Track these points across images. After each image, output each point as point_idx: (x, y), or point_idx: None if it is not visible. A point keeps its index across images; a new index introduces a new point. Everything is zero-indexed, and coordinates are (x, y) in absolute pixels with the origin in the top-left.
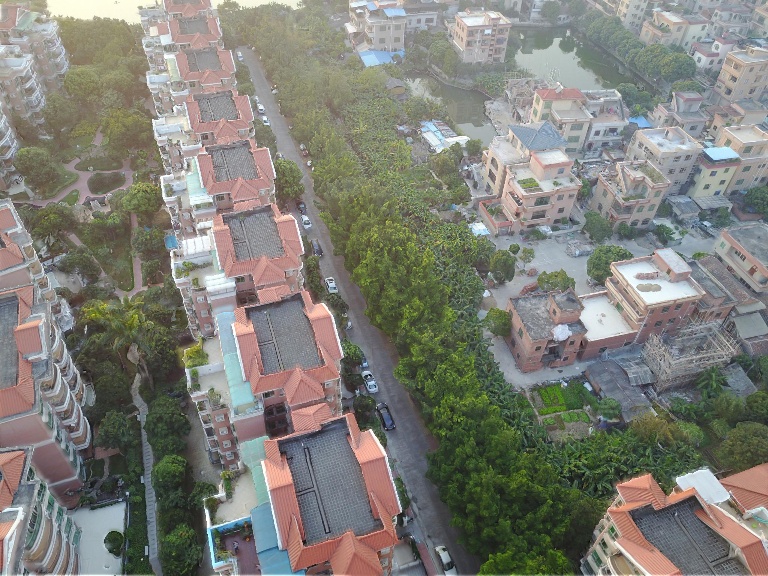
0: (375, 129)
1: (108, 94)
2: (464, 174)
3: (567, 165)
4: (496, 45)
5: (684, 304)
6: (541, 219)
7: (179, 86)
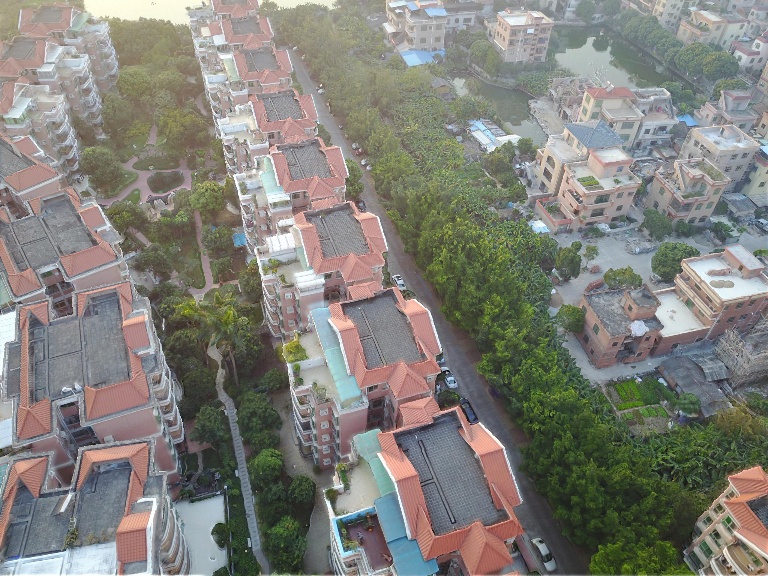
0: (425, 128)
1: (162, 94)
2: (517, 172)
3: (627, 163)
4: (538, 44)
5: (758, 300)
6: (600, 217)
7: (237, 86)
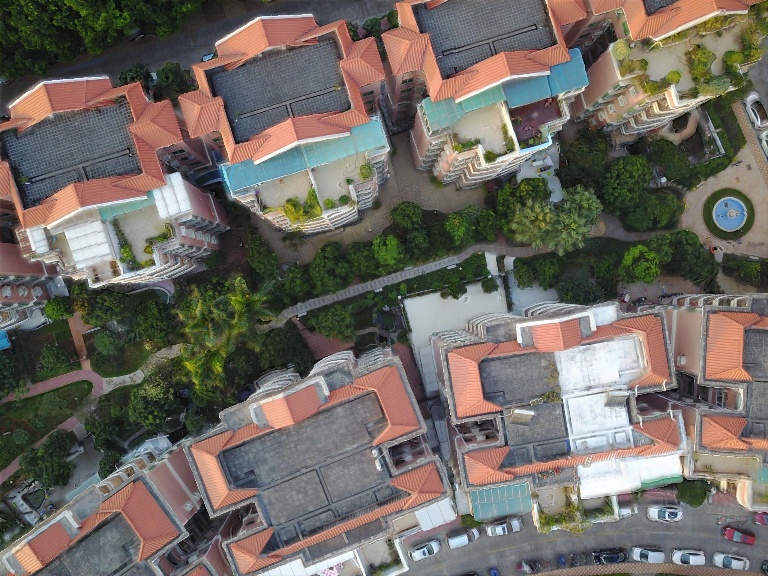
0: None
1: None
2: None
3: None
4: None
5: None
6: None
7: None
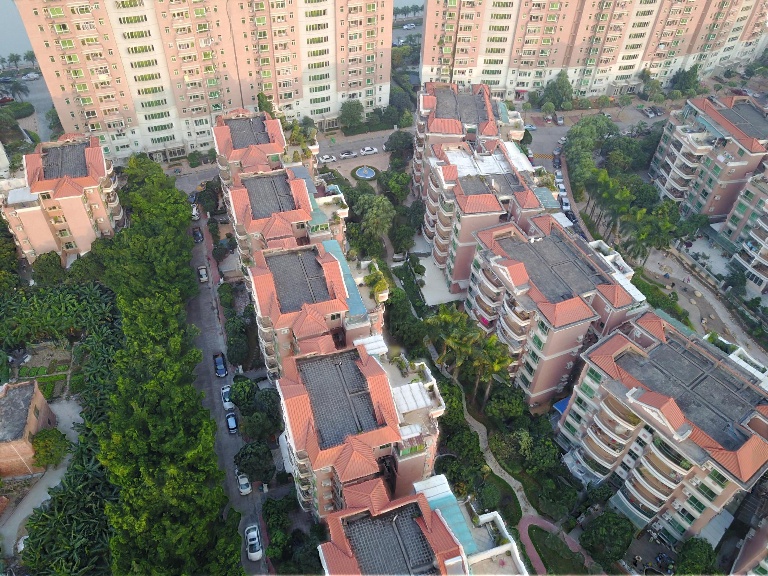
0: None
1: None
2: None
3: None
4: None
5: None
6: None
7: None
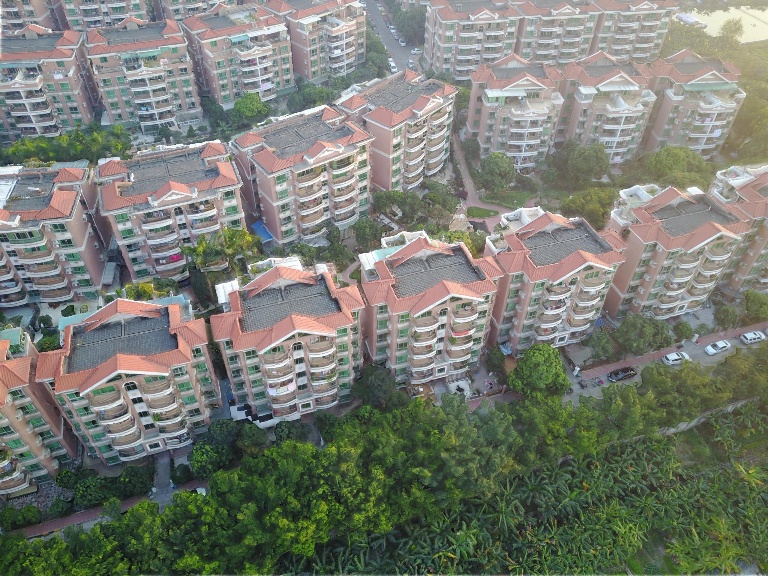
0: None
1: None
2: None
3: None
4: None
5: None
6: None
7: None
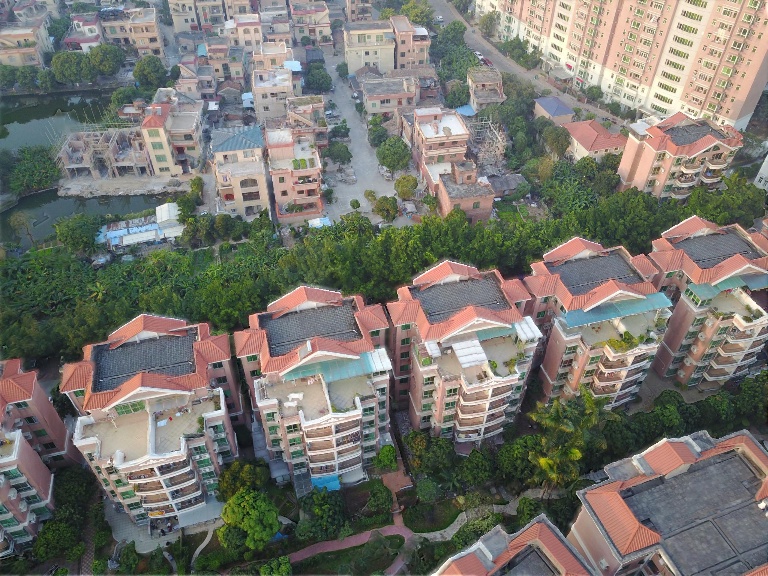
0: None
1: None
2: None
3: None
4: None
5: None
6: None
7: None
